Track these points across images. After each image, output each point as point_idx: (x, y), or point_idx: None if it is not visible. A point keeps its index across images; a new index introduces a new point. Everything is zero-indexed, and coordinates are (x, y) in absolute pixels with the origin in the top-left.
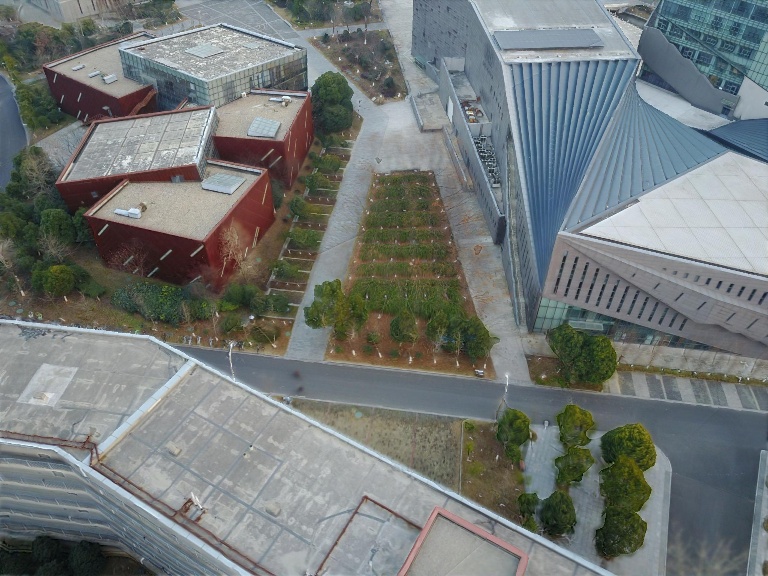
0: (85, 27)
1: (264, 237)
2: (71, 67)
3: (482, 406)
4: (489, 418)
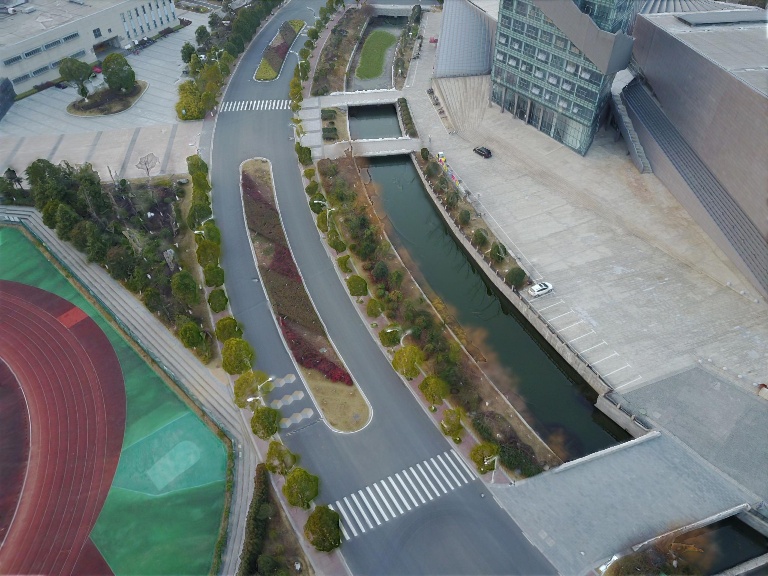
0: None
1: None
2: None
3: None
4: None
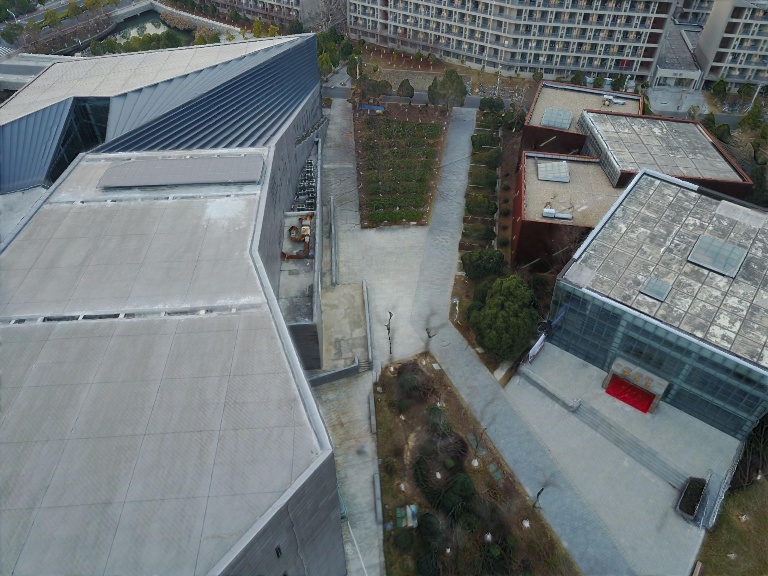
0: None
1: None
2: None
3: None
4: None
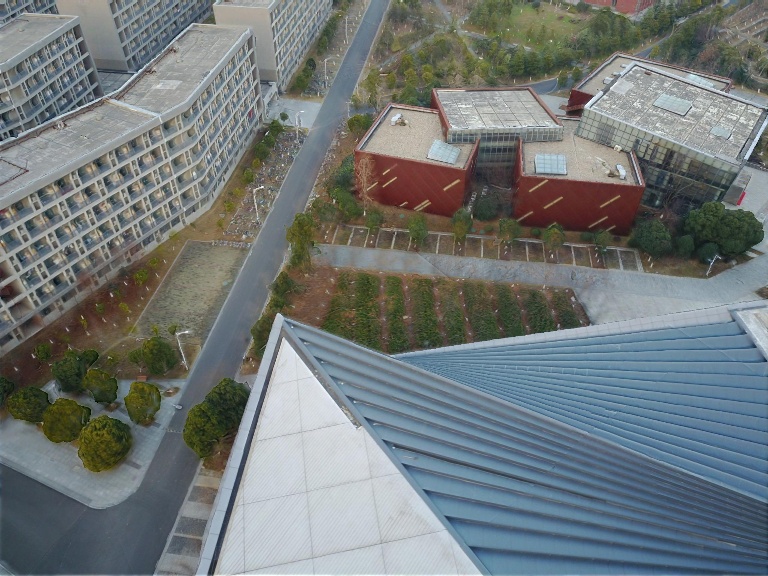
0: None
1: (432, 215)
2: (626, 64)
3: (211, 360)
4: (198, 364)
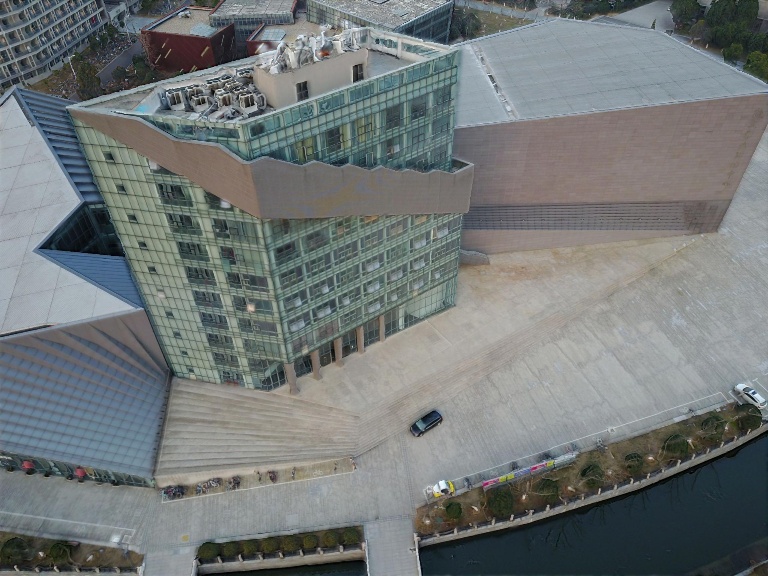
0: None
1: None
2: None
3: None
4: None
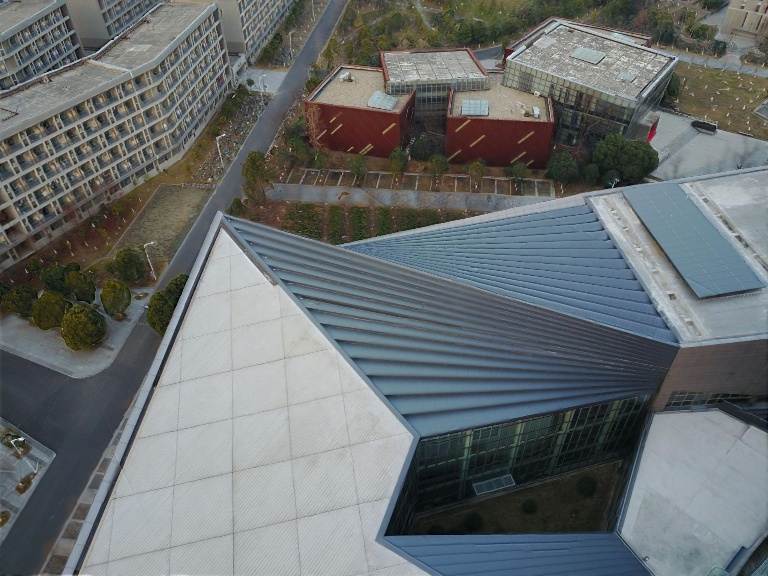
0: (698, 30)
1: (375, 157)
2: None
3: (176, 272)
4: (165, 276)
